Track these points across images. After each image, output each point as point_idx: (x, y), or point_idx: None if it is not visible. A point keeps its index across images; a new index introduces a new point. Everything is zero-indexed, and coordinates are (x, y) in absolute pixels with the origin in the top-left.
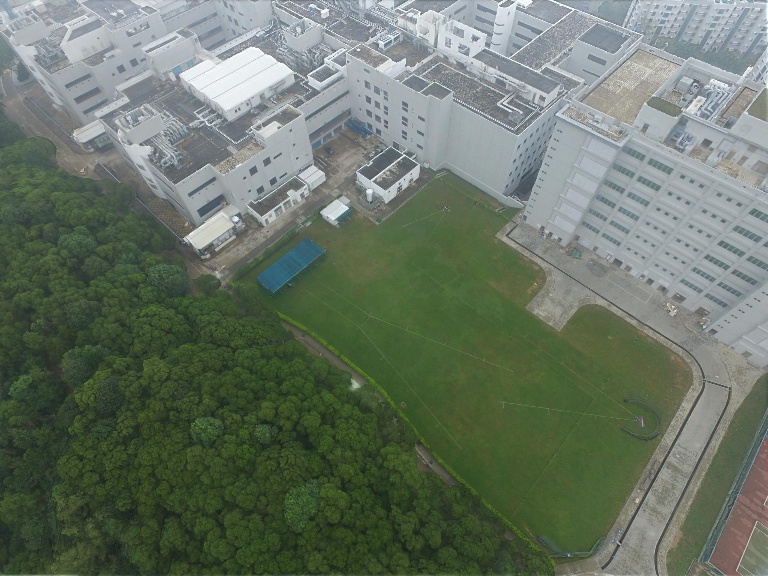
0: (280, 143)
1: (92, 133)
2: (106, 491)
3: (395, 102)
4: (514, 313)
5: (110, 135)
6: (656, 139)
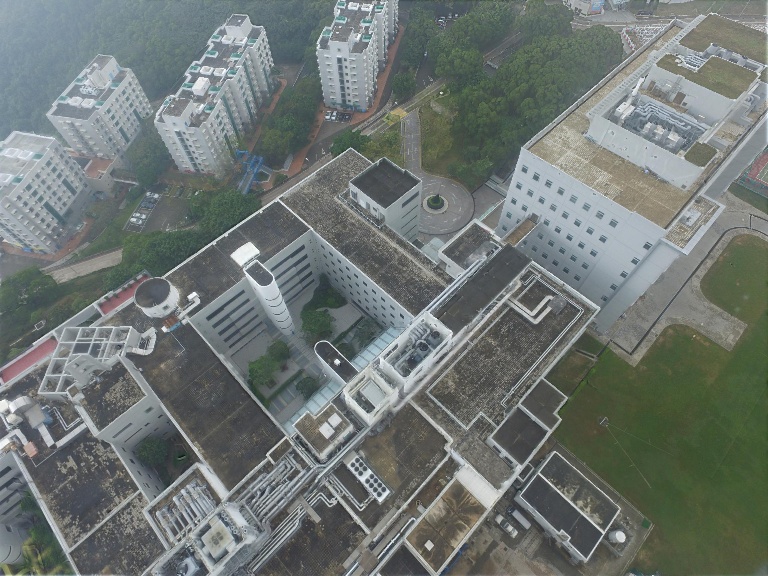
0: None
1: None
2: None
3: None
4: (743, 364)
5: None
6: (700, 176)
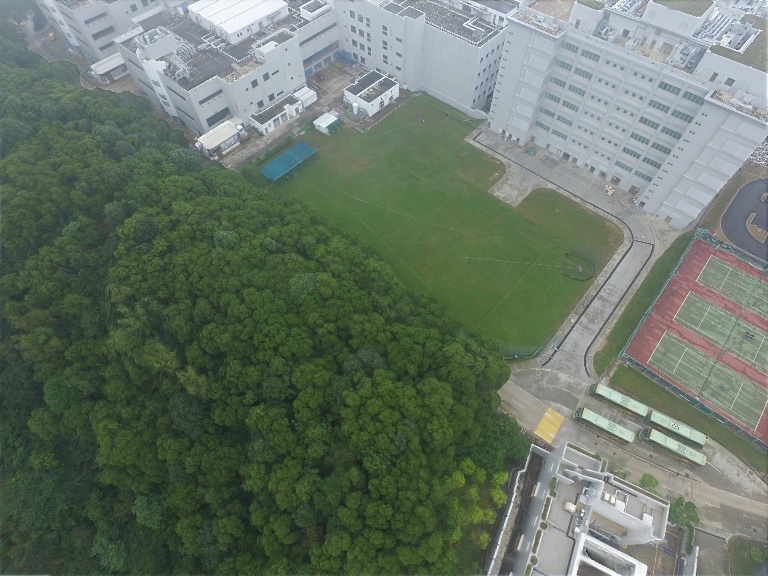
0: (277, 60)
1: (108, 66)
2: (149, 285)
3: (376, 27)
4: (478, 195)
5: (128, 59)
6: None
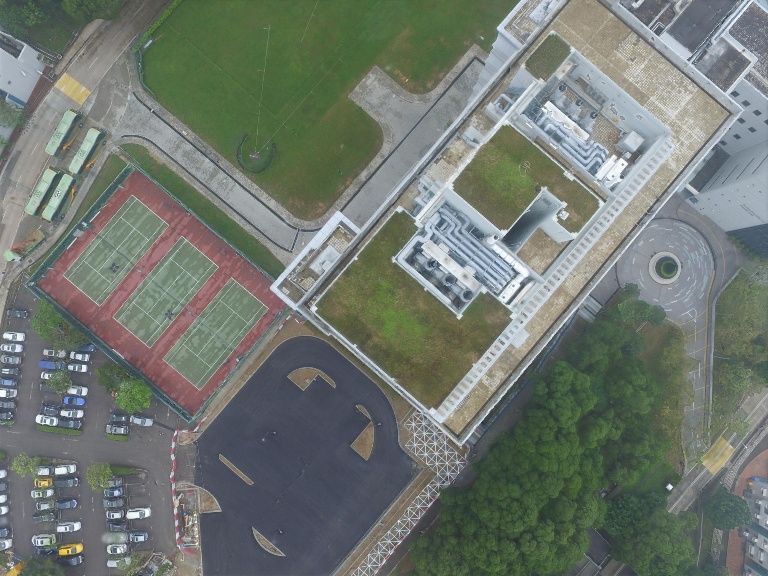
0: None
1: None
2: None
3: None
4: (368, 51)
5: None
6: None
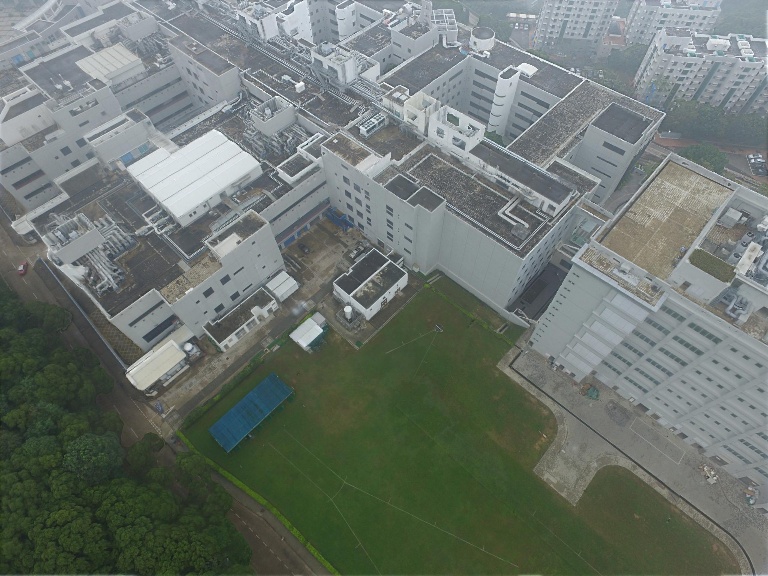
0: (241, 258)
1: None
2: None
3: (378, 204)
4: (519, 479)
5: None
6: (699, 300)
